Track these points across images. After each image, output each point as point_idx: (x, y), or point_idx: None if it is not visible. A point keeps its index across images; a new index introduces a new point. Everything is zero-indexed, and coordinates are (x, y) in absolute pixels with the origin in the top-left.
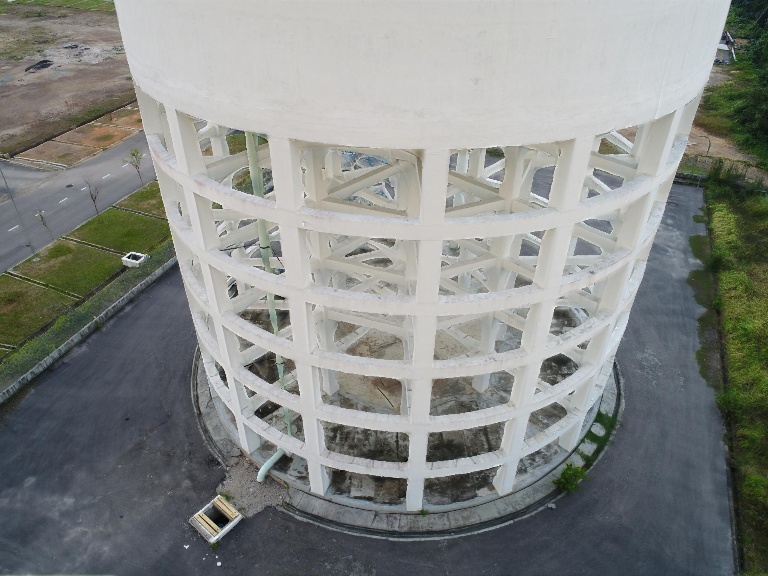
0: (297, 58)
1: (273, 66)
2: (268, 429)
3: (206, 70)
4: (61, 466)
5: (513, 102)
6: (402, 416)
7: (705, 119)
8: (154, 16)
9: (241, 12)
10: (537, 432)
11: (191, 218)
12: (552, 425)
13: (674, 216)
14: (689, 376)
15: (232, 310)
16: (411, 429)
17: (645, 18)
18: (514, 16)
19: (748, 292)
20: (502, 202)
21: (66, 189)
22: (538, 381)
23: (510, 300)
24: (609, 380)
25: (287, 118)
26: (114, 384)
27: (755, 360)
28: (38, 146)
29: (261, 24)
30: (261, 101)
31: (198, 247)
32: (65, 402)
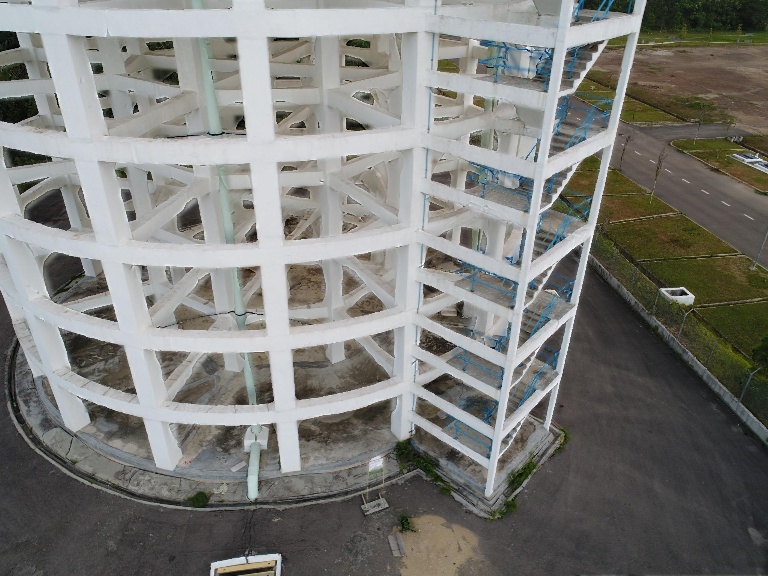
0: None
1: None
2: None
3: None
4: None
5: None
6: None
7: None
8: None
9: None
10: None
11: None
12: None
13: None
14: None
15: None
16: None
17: None
18: None
19: None
20: None
21: None
22: None
23: None
24: None
25: None
26: None
27: None
28: None
29: None
30: None
31: None
32: None
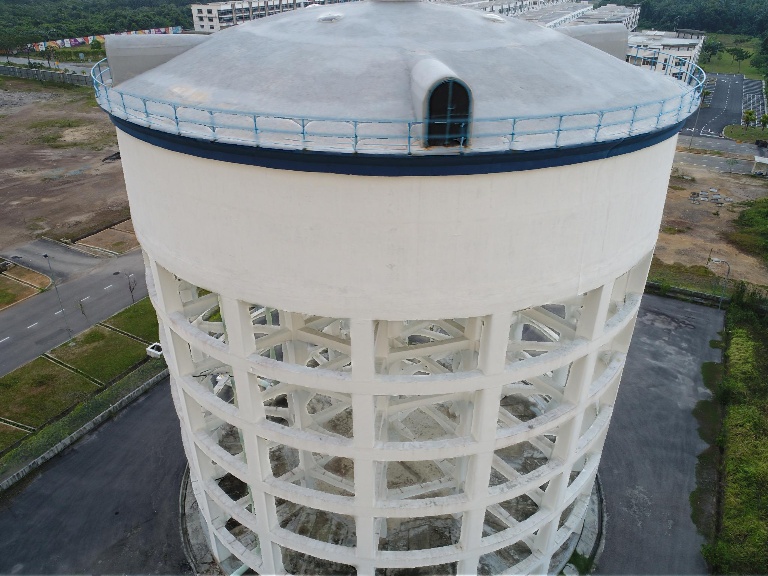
0: (241, 238)
1: (223, 242)
2: (233, 542)
3: (175, 237)
4: (48, 556)
5: (427, 284)
6: (350, 548)
7: (738, 236)
8: (140, 188)
9: (198, 199)
10: (506, 568)
11: (169, 347)
12: (511, 567)
13: (690, 339)
14: (679, 520)
15: (204, 428)
16: (357, 562)
17: (551, 216)
18: (421, 218)
19: (757, 430)
20: (466, 342)
21: (113, 276)
22: (506, 516)
23: (443, 451)
24: (591, 517)
25: (235, 283)
26: (113, 476)
27: (753, 508)
28: (98, 233)
29: (213, 210)
30: (215, 267)
31: (174, 372)
32: (66, 490)
